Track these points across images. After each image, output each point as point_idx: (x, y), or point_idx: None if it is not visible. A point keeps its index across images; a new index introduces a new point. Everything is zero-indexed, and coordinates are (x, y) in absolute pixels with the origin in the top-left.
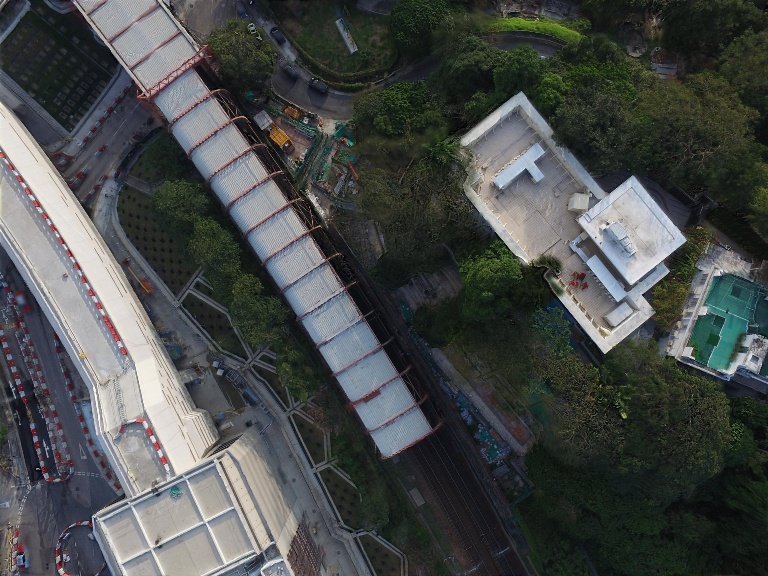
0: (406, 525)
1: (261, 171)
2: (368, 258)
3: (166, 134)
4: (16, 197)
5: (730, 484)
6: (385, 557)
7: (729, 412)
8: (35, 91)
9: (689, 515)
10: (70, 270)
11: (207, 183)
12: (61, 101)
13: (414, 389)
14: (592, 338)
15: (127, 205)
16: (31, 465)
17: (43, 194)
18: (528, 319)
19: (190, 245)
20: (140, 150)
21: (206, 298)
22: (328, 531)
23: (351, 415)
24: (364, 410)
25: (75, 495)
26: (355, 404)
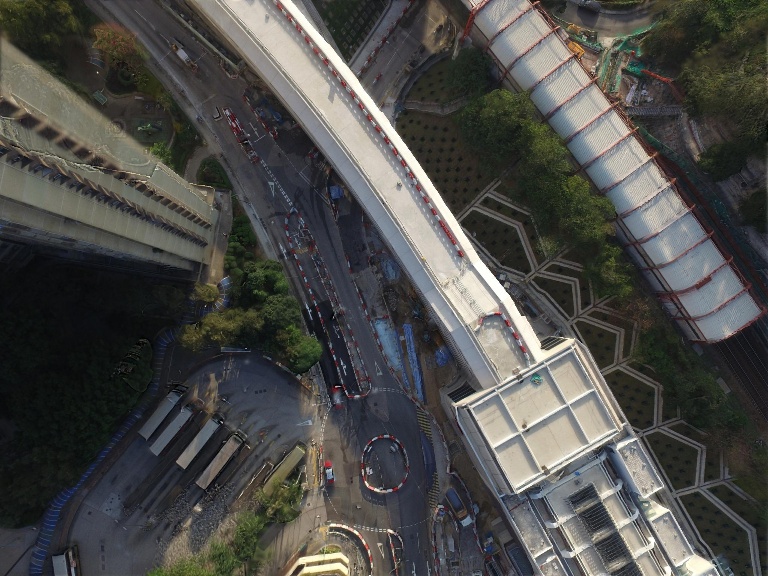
0: None
1: (584, 76)
2: (674, 159)
3: (474, 50)
4: (348, 112)
5: None
6: (678, 451)
7: None
8: (329, 20)
9: None
10: (404, 179)
11: (530, 91)
12: (346, 31)
13: (741, 275)
14: None
15: (409, 129)
16: (330, 383)
17: (371, 109)
18: None
19: (536, 144)
20: (414, 77)
21: (493, 213)
22: None
23: (659, 310)
24: (696, 296)
25: (374, 410)
26: (685, 292)
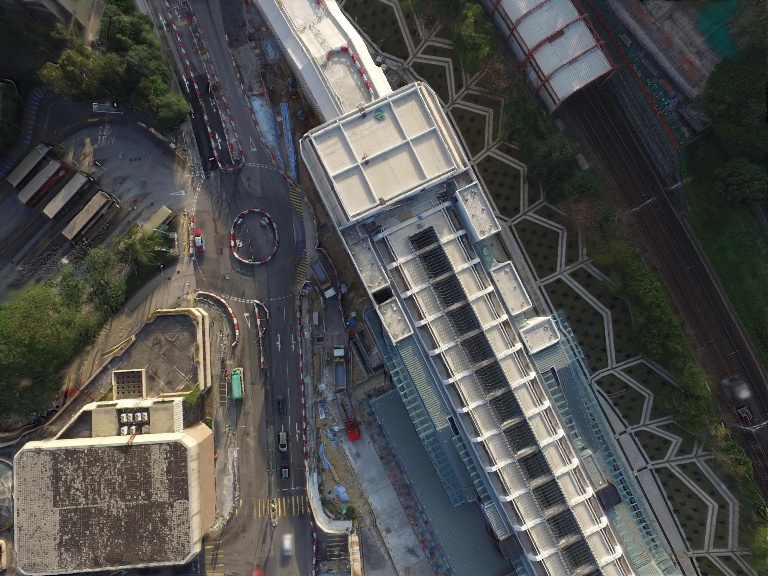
0: None
1: None
2: None
3: None
4: None
5: None
6: (542, 237)
7: None
8: None
9: None
10: None
11: None
12: None
13: (594, 31)
14: None
15: None
16: (204, 156)
17: None
18: None
19: None
20: None
21: None
22: None
23: (522, 81)
24: (548, 51)
25: None
26: (538, 47)
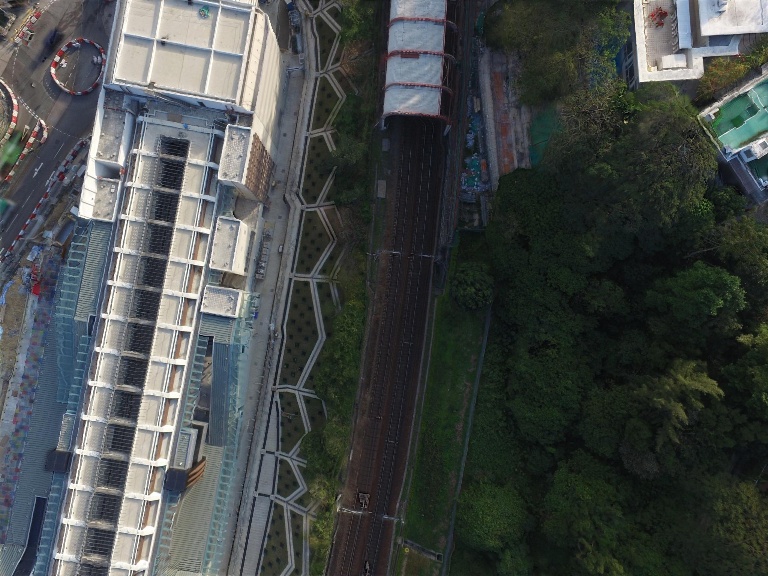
0: (361, 192)
1: None
2: None
3: None
4: None
5: (660, 279)
6: (317, 236)
7: (711, 183)
8: None
9: (609, 282)
10: None
11: None
12: None
13: (447, 75)
14: (639, 63)
15: None
16: None
17: None
18: (599, 9)
19: None
20: None
21: None
22: (283, 194)
23: (376, 84)
24: (396, 63)
25: (105, 19)
26: (391, 55)
